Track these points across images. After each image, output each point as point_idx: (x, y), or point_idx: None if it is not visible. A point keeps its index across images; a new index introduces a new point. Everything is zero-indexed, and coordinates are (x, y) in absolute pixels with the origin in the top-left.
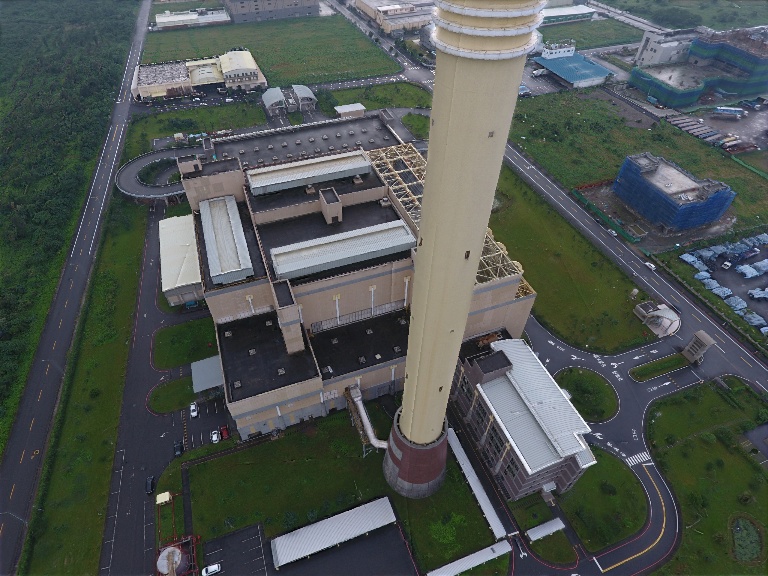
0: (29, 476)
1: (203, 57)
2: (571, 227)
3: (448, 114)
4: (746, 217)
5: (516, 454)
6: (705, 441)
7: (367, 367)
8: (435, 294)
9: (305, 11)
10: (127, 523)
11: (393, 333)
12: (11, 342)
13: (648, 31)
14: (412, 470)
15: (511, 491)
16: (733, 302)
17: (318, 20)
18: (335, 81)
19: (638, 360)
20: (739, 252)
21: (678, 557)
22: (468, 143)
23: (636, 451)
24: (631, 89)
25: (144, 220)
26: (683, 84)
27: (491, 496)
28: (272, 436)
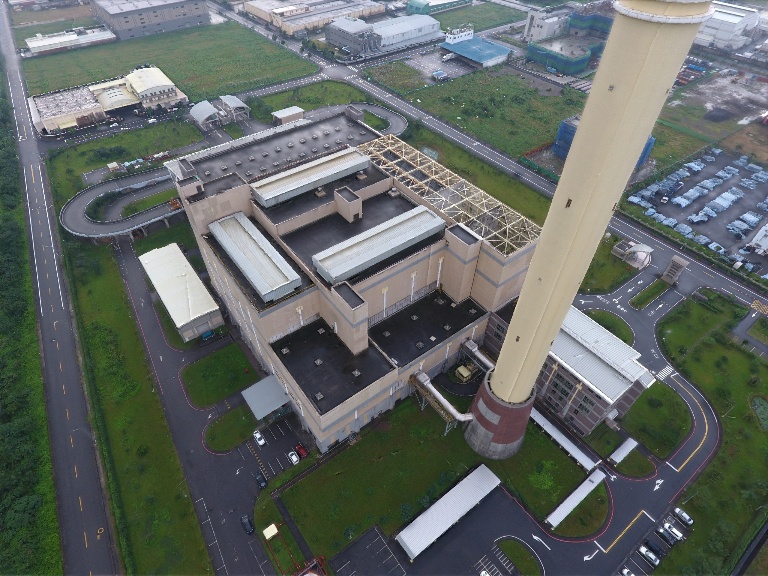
0: (104, 558)
1: (101, 79)
2: (533, 191)
3: (636, 78)
4: (662, 158)
5: (590, 391)
6: (707, 344)
7: (429, 350)
8: (576, 250)
9: (195, 20)
10: (240, 569)
11: (436, 314)
12: (16, 423)
13: (531, 10)
14: (509, 431)
15: (584, 427)
16: (681, 229)
17: (212, 28)
18: (257, 88)
19: (632, 292)
20: (668, 187)
21: (727, 441)
22: (649, 101)
23: (661, 367)
24: (531, 63)
25: (112, 260)
26: (574, 53)
27: (567, 437)
28: (350, 441)
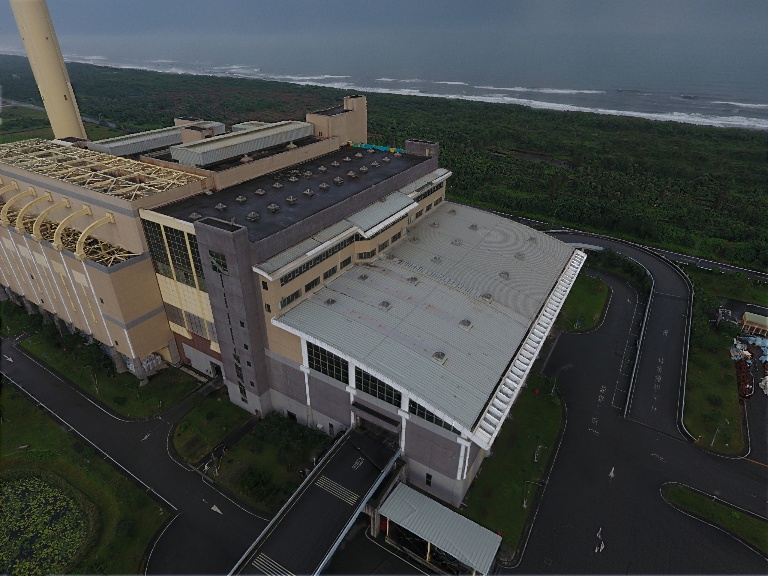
0: None
1: None
2: None
3: None
4: None
5: None
6: None
7: None
8: None
9: None
10: None
11: None
12: None
13: None
14: None
15: None
16: None
17: None
18: None
19: None
20: None
21: None
22: None
23: None
24: None
25: None
26: None
27: None
28: None
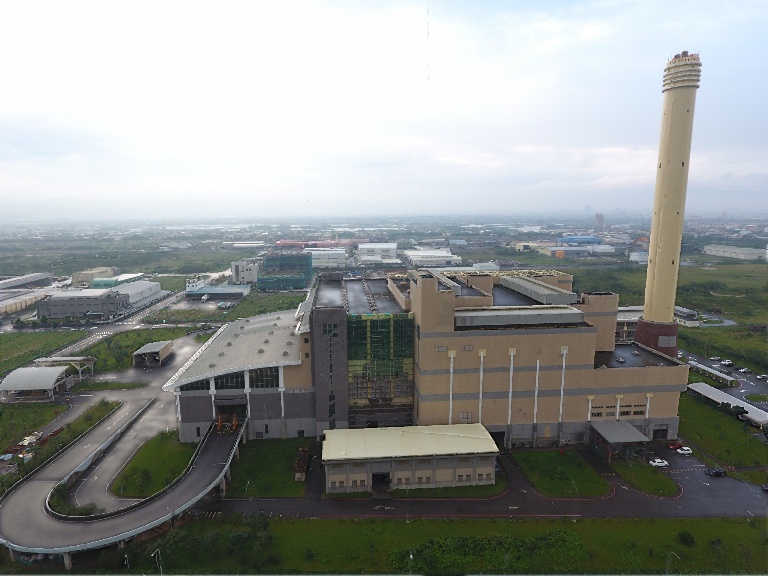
0: None
1: None
2: None
3: None
4: None
5: None
6: None
7: None
8: None
9: None
10: None
11: None
12: None
13: None
14: None
15: None
16: None
17: None
18: None
19: None
20: None
21: None
22: None
23: None
24: None
25: None
26: (294, 276)
27: None
28: None
